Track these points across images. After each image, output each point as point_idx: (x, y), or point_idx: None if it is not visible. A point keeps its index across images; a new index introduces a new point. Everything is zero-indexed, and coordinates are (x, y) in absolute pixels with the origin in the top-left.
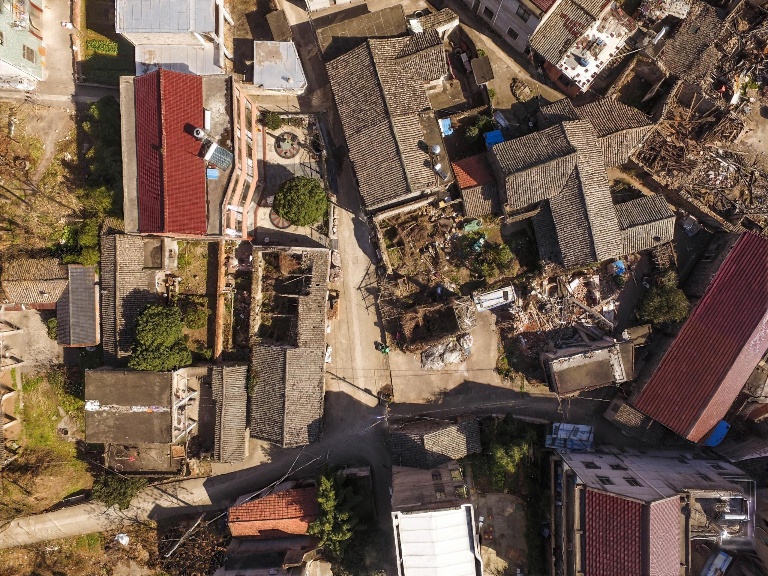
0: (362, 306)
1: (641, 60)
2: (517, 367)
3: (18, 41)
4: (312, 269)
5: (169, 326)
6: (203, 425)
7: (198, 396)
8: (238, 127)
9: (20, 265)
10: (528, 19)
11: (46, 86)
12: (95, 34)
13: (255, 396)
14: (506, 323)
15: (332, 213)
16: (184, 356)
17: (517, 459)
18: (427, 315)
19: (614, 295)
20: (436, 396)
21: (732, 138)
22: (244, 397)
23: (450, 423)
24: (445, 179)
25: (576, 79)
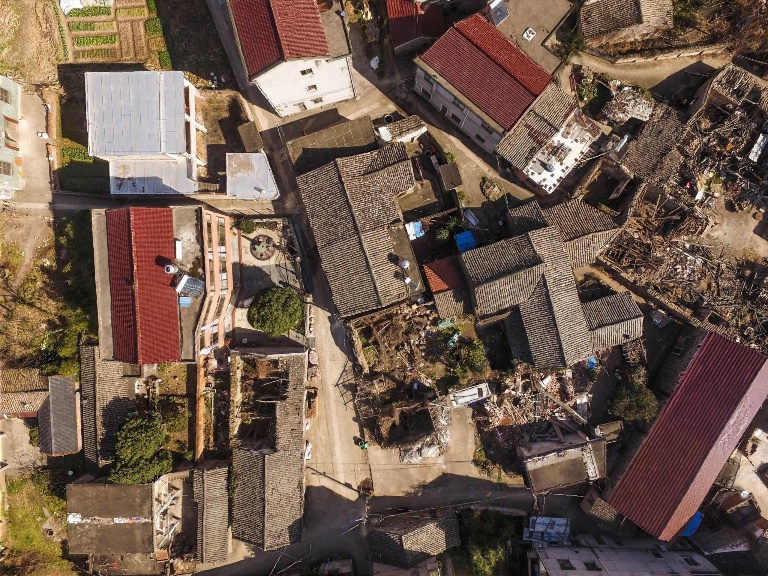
0: (340, 402)
1: (606, 162)
2: (494, 459)
3: None
4: (289, 374)
5: (148, 440)
6: (186, 522)
7: (181, 494)
8: (210, 250)
9: (1, 376)
10: (492, 133)
11: (24, 195)
12: (71, 142)
13: (236, 498)
14: (482, 417)
15: (308, 313)
16: (164, 466)
17: (493, 563)
18: (404, 411)
19: (587, 387)
20: (415, 489)
21: (698, 233)
22: (225, 498)
23: (429, 518)
24: (416, 289)
25: (542, 184)
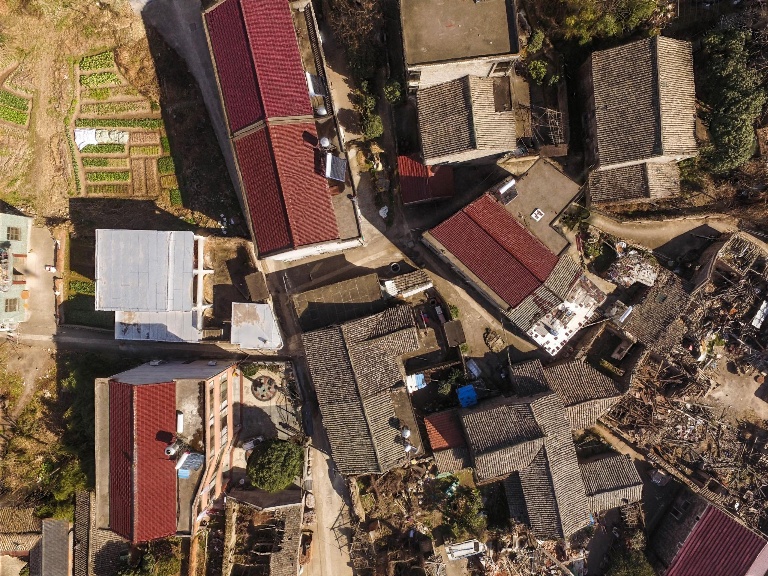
0: (335, 546)
1: (610, 326)
2: None
3: (1, 300)
4: (284, 524)
5: None
6: None
7: None
8: (211, 417)
9: None
10: None
11: (28, 326)
12: (78, 276)
13: None
14: (477, 570)
15: (307, 456)
16: None
17: None
18: None
19: (584, 542)
20: None
21: (699, 396)
22: None
23: None
24: (416, 452)
25: (546, 346)
